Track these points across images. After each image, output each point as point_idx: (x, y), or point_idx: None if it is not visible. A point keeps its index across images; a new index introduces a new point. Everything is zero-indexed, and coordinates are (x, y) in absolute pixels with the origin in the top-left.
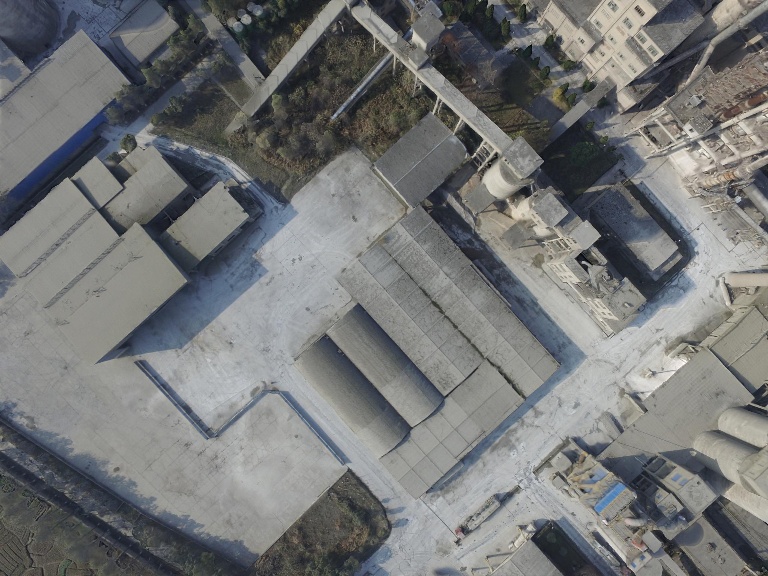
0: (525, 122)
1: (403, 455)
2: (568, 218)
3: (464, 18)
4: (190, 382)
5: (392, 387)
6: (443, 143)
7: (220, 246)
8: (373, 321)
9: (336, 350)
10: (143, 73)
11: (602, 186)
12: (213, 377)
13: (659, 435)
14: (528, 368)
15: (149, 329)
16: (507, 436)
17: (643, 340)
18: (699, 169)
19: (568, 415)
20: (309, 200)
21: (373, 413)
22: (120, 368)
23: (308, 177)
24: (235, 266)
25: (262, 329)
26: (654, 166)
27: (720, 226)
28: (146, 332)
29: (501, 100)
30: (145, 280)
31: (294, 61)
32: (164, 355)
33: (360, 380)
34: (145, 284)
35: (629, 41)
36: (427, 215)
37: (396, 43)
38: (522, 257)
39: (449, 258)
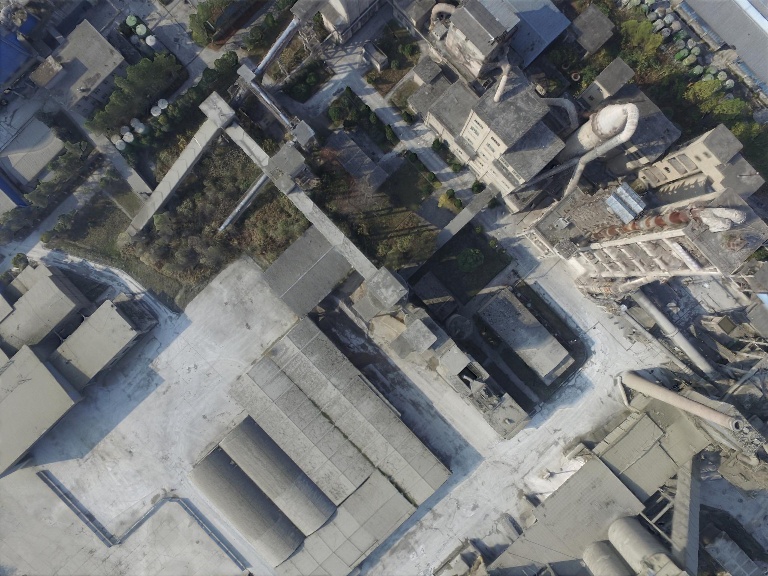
0: (415, 225)
1: (297, 565)
2: (440, 341)
3: (348, 125)
4: (92, 491)
5: (283, 499)
6: (328, 254)
7: (114, 359)
8: (264, 433)
9: (228, 462)
10: (26, 198)
11: (495, 287)
12: (114, 485)
13: (549, 545)
14: (419, 477)
15: (50, 440)
16: (406, 539)
17: (541, 441)
18: (586, 274)
19: (467, 517)
20: (202, 309)
21: (265, 525)
22: (24, 478)
23: (201, 286)
24: (132, 376)
25: (160, 437)
26: (548, 266)
27: (617, 325)
28: (48, 443)
29: (390, 204)
30: (34, 402)
31: (176, 178)
32: (66, 465)
33: (252, 491)
34: (34, 406)
35: (495, 163)
36: (314, 326)
37: (267, 166)
38: (416, 360)
39: (337, 369)
